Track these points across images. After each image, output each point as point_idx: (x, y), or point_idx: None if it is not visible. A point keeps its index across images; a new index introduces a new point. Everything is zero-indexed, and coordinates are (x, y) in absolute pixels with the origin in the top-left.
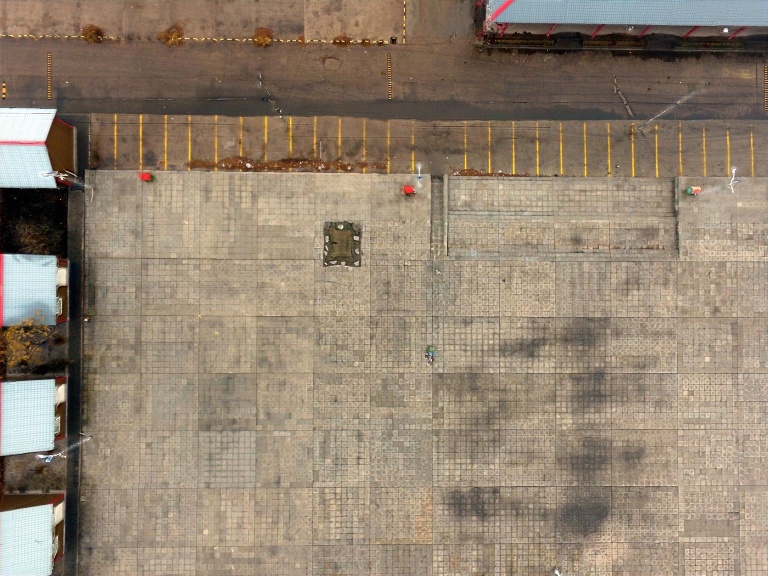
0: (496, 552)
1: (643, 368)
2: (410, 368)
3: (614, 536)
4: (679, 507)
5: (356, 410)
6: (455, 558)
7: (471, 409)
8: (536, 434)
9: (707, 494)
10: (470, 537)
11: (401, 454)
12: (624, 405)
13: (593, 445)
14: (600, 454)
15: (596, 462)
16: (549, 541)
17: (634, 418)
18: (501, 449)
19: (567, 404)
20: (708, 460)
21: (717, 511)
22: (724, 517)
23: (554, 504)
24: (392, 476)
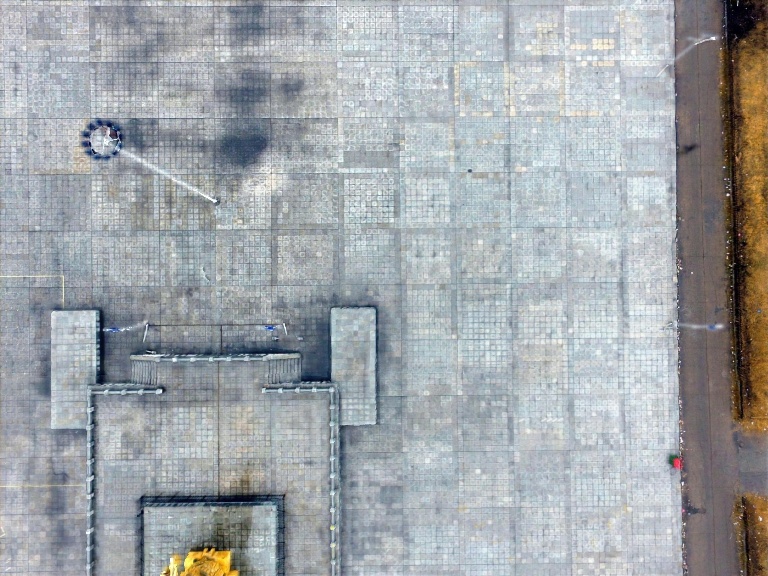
0: (155, 183)
1: (302, 1)
2: (67, 1)
3: (273, 167)
4: (338, 139)
5: (12, 42)
6: (114, 188)
7: (129, 42)
8: (194, 67)
9: (367, 126)
10: (129, 168)
11: (59, 86)
12: (283, 38)
13: (252, 77)
14: (259, 86)
15: (255, 94)
16: (208, 172)
17: (293, 51)
18: (159, 82)
19: (225, 37)
20: (368, 92)
21: (377, 142)
22: (384, 148)
23: (213, 136)
24: (50, 108)
